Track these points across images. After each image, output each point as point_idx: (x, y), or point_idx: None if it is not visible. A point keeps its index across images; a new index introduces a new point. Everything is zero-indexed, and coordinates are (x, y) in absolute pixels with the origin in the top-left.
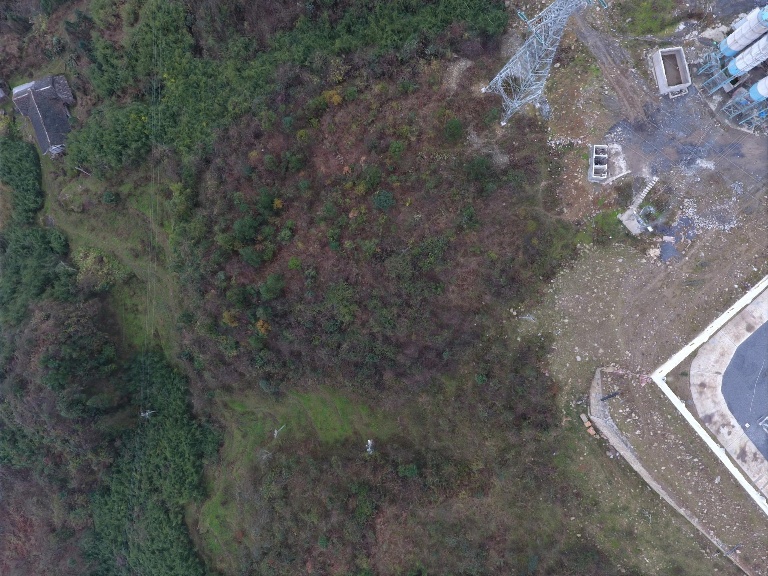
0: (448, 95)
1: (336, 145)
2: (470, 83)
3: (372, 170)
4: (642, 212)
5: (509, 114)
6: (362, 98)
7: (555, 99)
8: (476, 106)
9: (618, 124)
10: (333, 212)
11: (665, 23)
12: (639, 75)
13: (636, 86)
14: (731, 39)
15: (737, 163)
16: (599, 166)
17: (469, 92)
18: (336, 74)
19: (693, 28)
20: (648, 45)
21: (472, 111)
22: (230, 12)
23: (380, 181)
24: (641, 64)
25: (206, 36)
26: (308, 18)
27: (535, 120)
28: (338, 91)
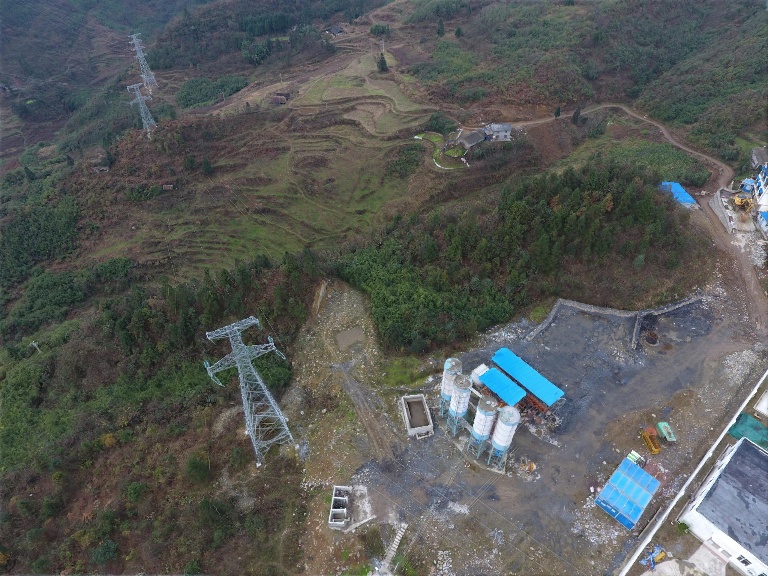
0: (213, 437)
1: (99, 488)
2: (236, 426)
3: (101, 515)
4: (396, 569)
5: (262, 455)
6: (133, 440)
7: (314, 441)
8: (236, 447)
9: (366, 464)
10: (42, 569)
11: (414, 376)
12: (391, 419)
13: (386, 428)
14: (442, 386)
15: (493, 507)
16: (337, 510)
17: (232, 434)
18: (123, 419)
19: (441, 380)
20: (398, 393)
21: (230, 452)
22: (72, 371)
23: (113, 529)
24: (392, 409)
25: (50, 390)
26: (128, 375)
27: (293, 461)
28: (115, 434)
